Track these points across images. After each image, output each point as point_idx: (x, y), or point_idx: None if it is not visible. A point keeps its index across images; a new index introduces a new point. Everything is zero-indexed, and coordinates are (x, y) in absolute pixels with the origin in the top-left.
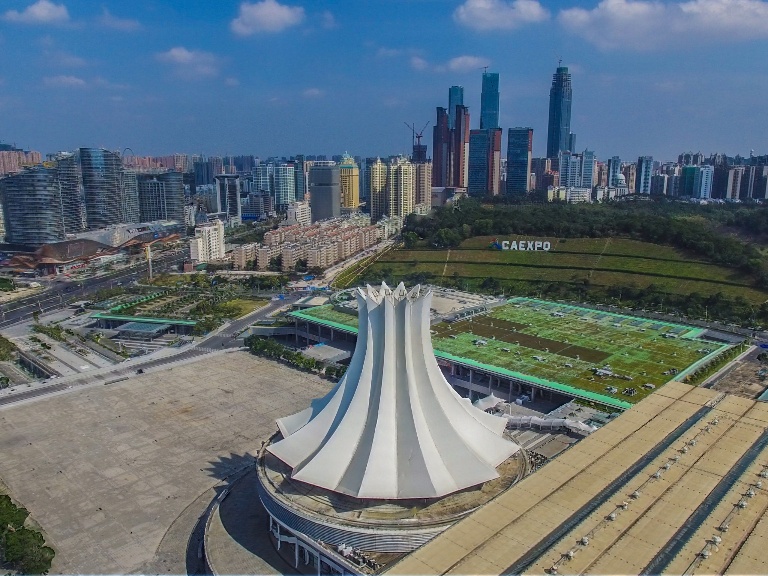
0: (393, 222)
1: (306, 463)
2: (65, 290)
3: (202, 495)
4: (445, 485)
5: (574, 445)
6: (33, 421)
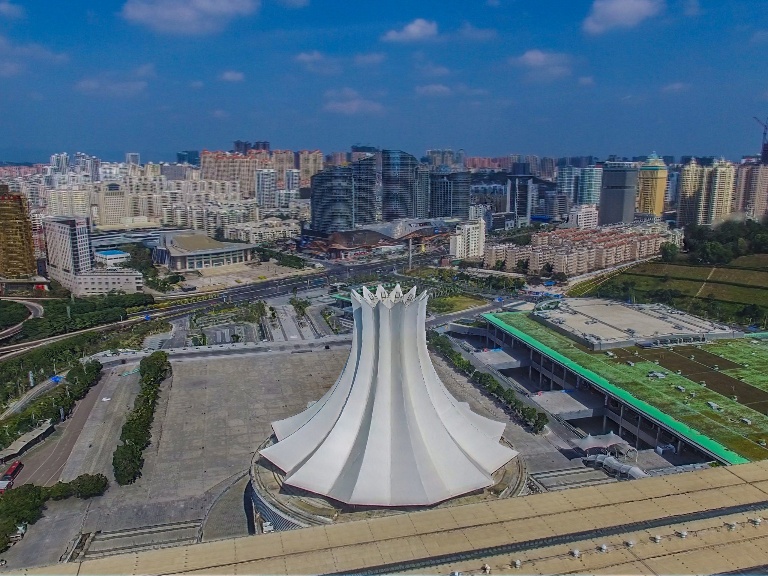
0: None
1: None
2: (338, 272)
3: None
4: (372, 496)
5: None
6: (222, 371)
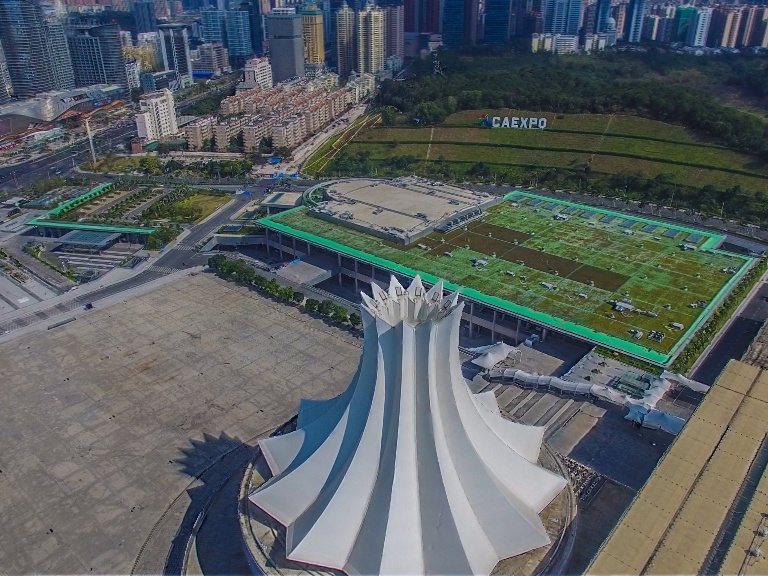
0: (364, 82)
1: (304, 532)
2: None
3: (174, 503)
4: (484, 561)
5: (640, 492)
6: None
